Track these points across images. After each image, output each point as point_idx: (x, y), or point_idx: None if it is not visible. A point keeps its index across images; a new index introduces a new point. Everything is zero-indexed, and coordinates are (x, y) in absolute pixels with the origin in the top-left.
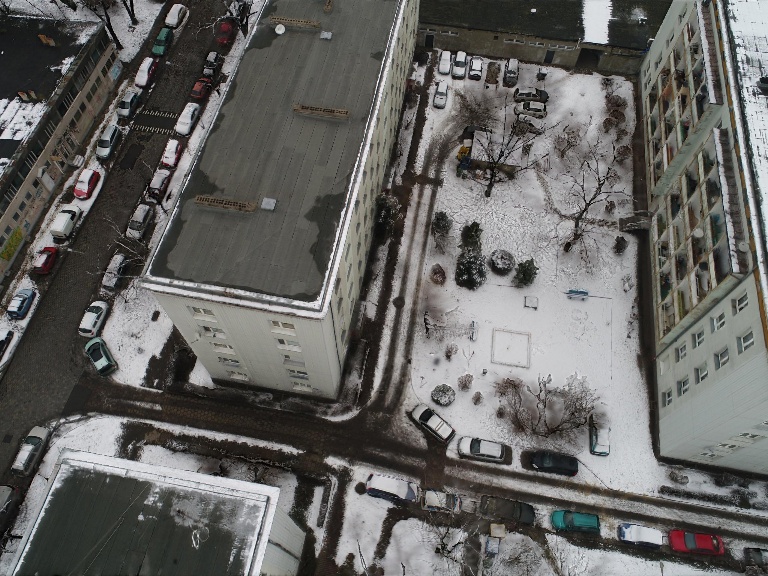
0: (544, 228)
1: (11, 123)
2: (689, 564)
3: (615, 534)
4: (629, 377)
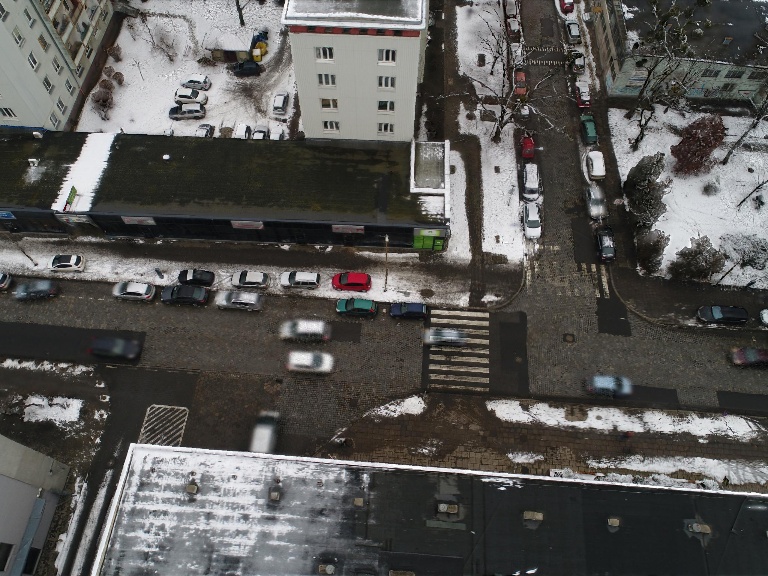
0: (200, 8)
1: None
2: None
3: None
4: None
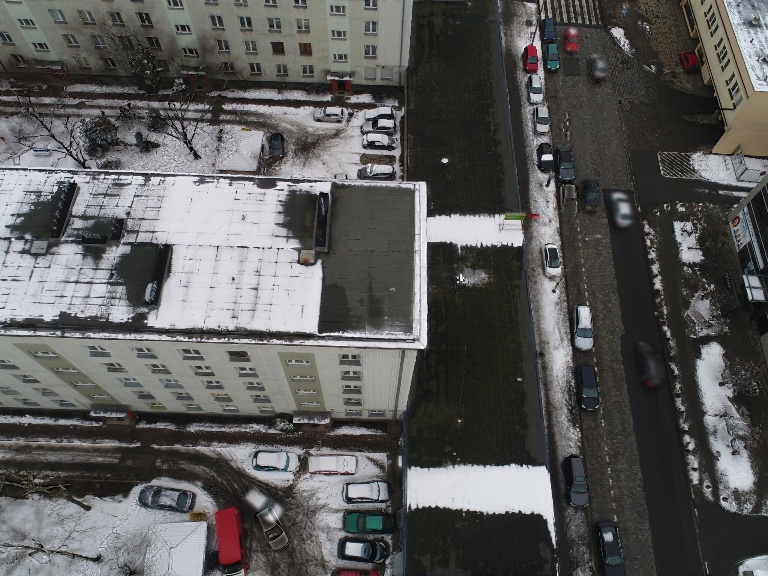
0: None
1: None
2: None
3: None
4: None
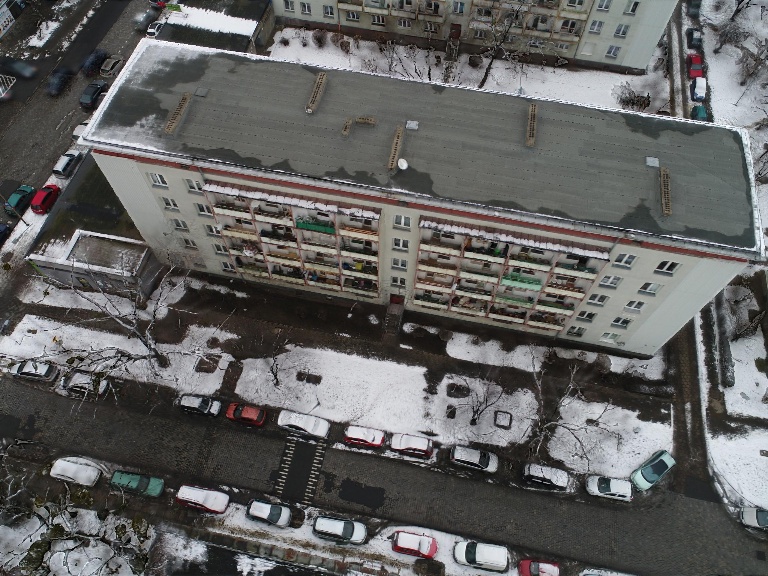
0: None
1: None
2: (706, 73)
3: (699, 103)
4: (586, 78)
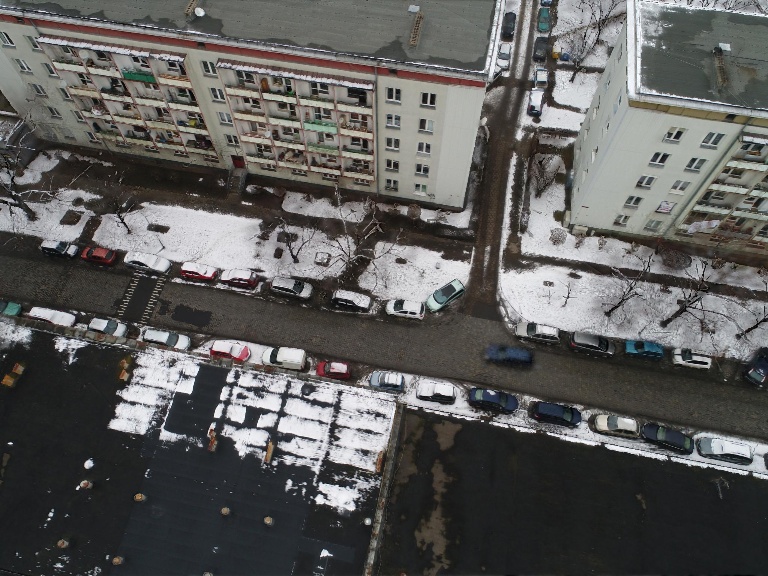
0: None
1: (166, 387)
2: None
3: None
4: None
